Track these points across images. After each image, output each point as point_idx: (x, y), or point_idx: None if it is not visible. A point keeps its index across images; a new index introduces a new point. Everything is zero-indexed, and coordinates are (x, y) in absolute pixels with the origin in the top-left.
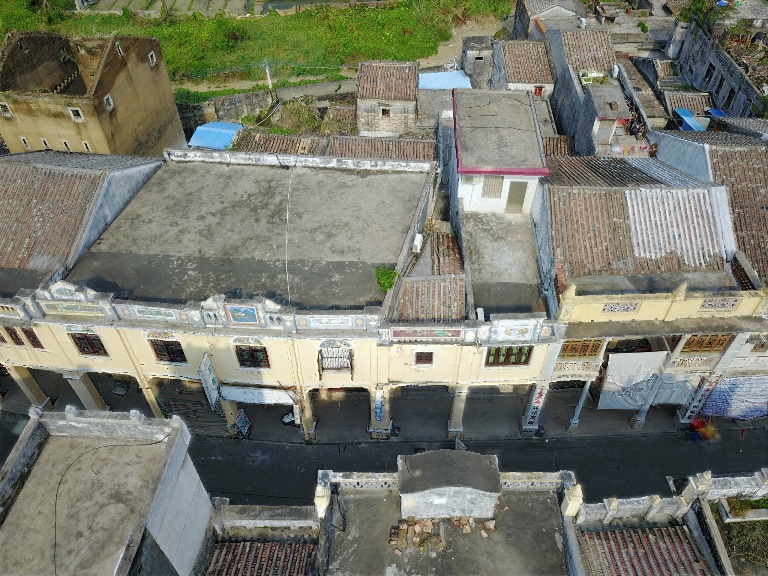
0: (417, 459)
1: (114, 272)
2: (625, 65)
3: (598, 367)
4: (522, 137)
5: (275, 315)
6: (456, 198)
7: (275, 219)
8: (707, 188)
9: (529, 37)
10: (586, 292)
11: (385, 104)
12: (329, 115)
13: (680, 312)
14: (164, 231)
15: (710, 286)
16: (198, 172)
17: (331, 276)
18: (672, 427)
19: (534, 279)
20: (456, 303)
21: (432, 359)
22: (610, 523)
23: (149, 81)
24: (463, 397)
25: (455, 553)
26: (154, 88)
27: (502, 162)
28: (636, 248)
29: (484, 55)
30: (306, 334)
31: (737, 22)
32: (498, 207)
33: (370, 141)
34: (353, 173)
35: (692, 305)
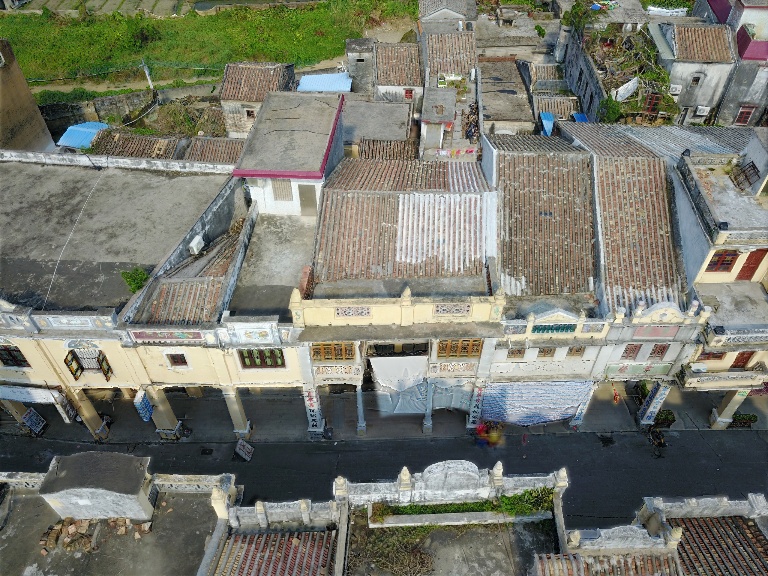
0: (69, 460)
1: None
2: (509, 68)
3: (359, 371)
4: (313, 140)
5: None
6: None
7: (66, 219)
8: (480, 193)
9: None
10: (337, 296)
11: (248, 105)
12: (204, 116)
13: (415, 317)
14: None
15: (462, 291)
16: (11, 172)
17: (96, 277)
18: (463, 432)
19: None
20: (209, 305)
21: (186, 361)
22: (268, 527)
23: None
24: (233, 399)
25: (101, 554)
26: (3, 88)
27: (281, 165)
28: (398, 252)
29: (365, 57)
30: (48, 334)
31: (604, 26)
32: (294, 210)
33: (231, 142)
34: (162, 174)
35: (424, 310)
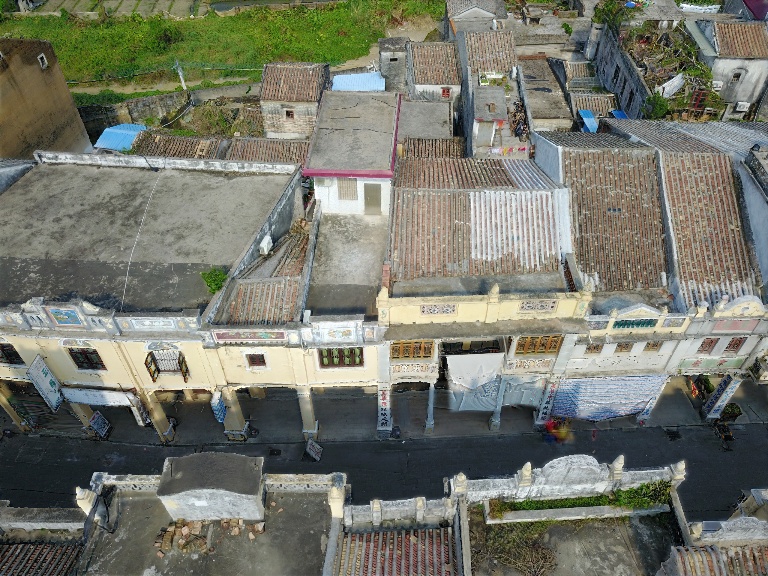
0: (182, 461)
1: None
2: (541, 66)
3: (436, 369)
4: (377, 139)
5: None
6: None
7: (130, 221)
8: (550, 190)
9: None
10: (416, 294)
11: (288, 106)
12: (240, 117)
13: (500, 314)
14: (17, 233)
15: (540, 288)
16: (67, 174)
17: (170, 278)
18: (530, 428)
19: (376, 281)
20: (288, 305)
21: (265, 361)
22: (381, 525)
23: (39, 83)
24: (307, 399)
25: (217, 555)
26: (46, 90)
27: (350, 164)
28: (473, 250)
29: (398, 56)
30: (130, 336)
31: (641, 23)
32: (357, 209)
33: (272, 143)
34: (221, 175)
35: (510, 307)
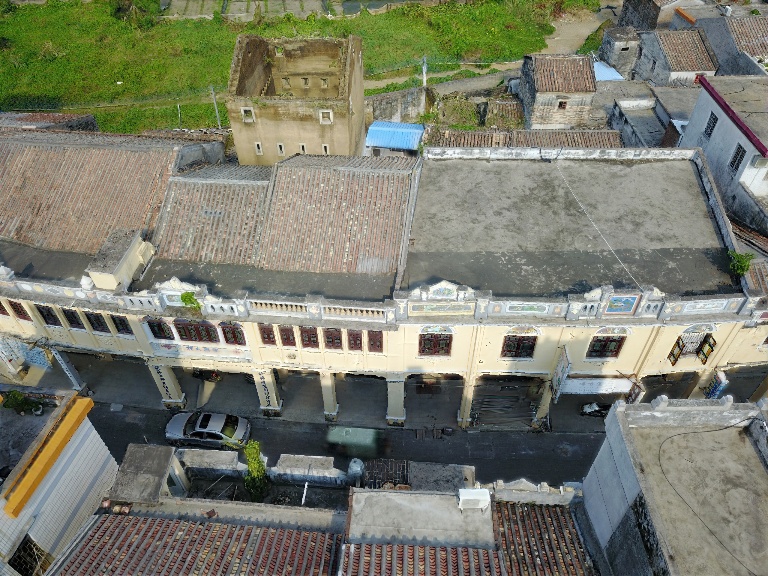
0: None
1: (448, 271)
2: None
3: None
4: None
5: (655, 303)
6: (731, 183)
7: (572, 211)
8: None
9: (657, 27)
10: None
11: (564, 97)
12: (491, 110)
13: None
14: (470, 228)
15: None
16: (463, 169)
17: (666, 263)
18: None
19: None
20: None
21: None
22: None
23: (359, 81)
24: None
25: None
26: (360, 88)
27: None
28: None
29: (630, 46)
30: (680, 320)
31: None
32: None
33: (554, 134)
34: (617, 163)
35: None
